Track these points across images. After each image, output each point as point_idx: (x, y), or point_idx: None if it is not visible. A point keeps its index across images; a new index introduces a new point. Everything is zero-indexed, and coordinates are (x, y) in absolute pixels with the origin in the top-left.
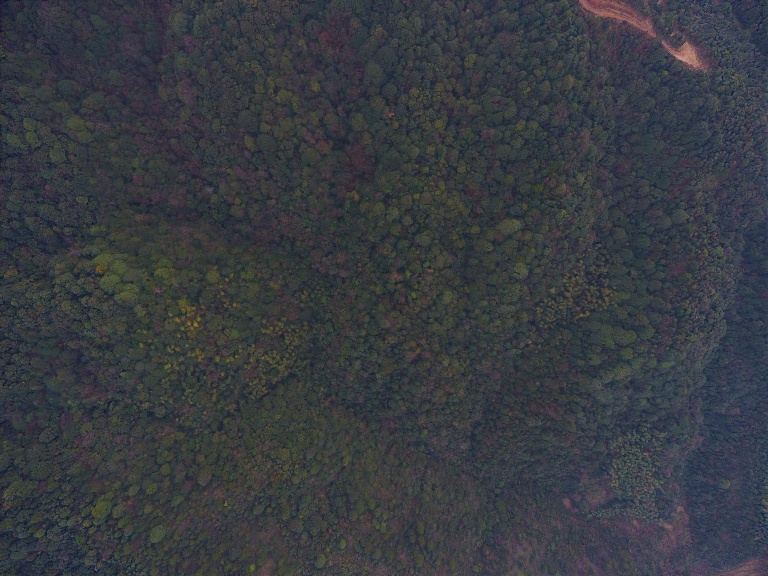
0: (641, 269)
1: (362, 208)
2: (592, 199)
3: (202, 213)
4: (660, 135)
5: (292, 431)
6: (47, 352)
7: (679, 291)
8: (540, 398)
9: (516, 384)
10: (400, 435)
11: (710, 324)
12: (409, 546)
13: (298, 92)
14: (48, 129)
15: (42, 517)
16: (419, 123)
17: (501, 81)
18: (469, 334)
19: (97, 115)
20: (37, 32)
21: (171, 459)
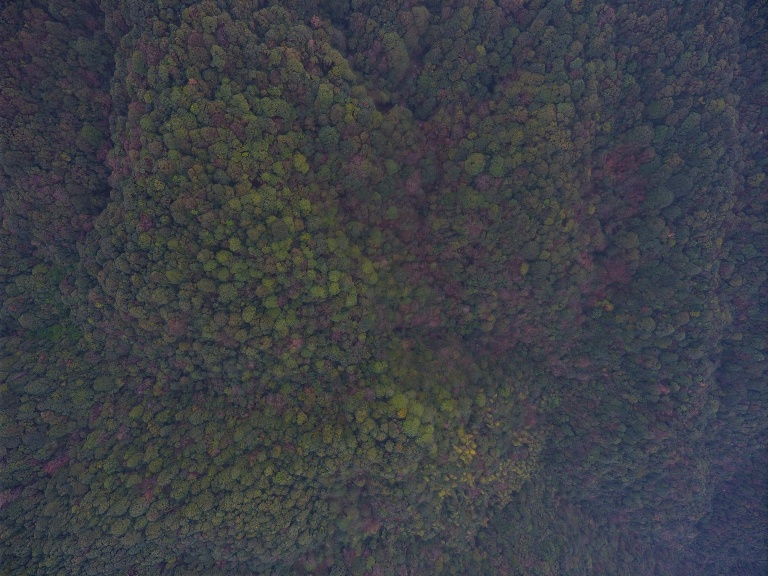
0: None
1: (620, 319)
2: None
3: (448, 328)
4: None
5: (543, 540)
6: (339, 494)
7: None
8: None
9: (754, 476)
10: (626, 528)
11: None
12: None
13: None
14: (350, 278)
15: None
16: (700, 242)
17: None
18: (716, 433)
19: (378, 253)
20: (332, 180)
21: None
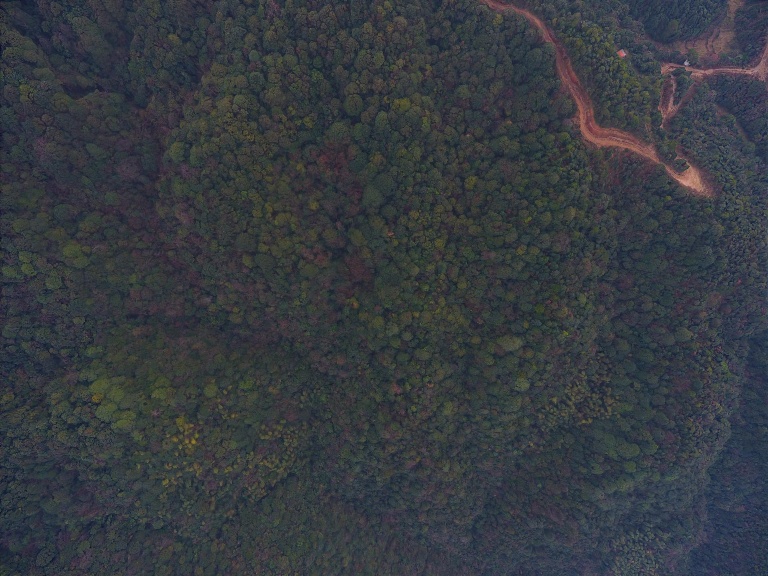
0: (644, 381)
1: (361, 317)
2: (594, 315)
3: (200, 318)
4: (663, 255)
5: (291, 535)
6: (44, 476)
7: (683, 408)
8: (542, 500)
9: (518, 482)
10: (400, 528)
11: (714, 433)
12: None
13: (296, 211)
14: (44, 260)
15: None
16: (419, 243)
17: (502, 207)
18: (470, 437)
19: (94, 237)
20: (33, 161)
21: (169, 573)
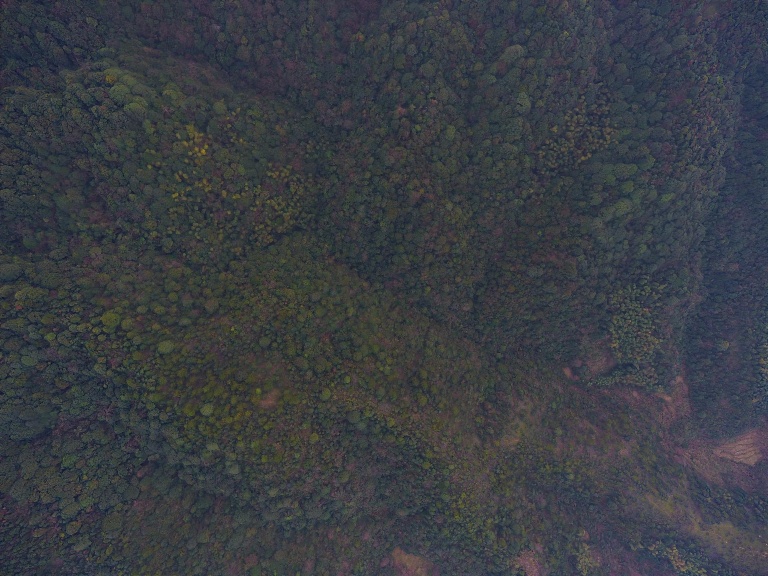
0: (642, 103)
1: (367, 46)
2: (594, 28)
3: (209, 57)
4: None
5: (297, 277)
6: (57, 169)
7: (679, 118)
8: (542, 248)
9: (518, 239)
10: (403, 297)
11: (710, 163)
12: (412, 390)
13: None
14: None
15: (53, 320)
16: None
17: None
18: (472, 182)
19: None
20: None
21: (178, 290)
